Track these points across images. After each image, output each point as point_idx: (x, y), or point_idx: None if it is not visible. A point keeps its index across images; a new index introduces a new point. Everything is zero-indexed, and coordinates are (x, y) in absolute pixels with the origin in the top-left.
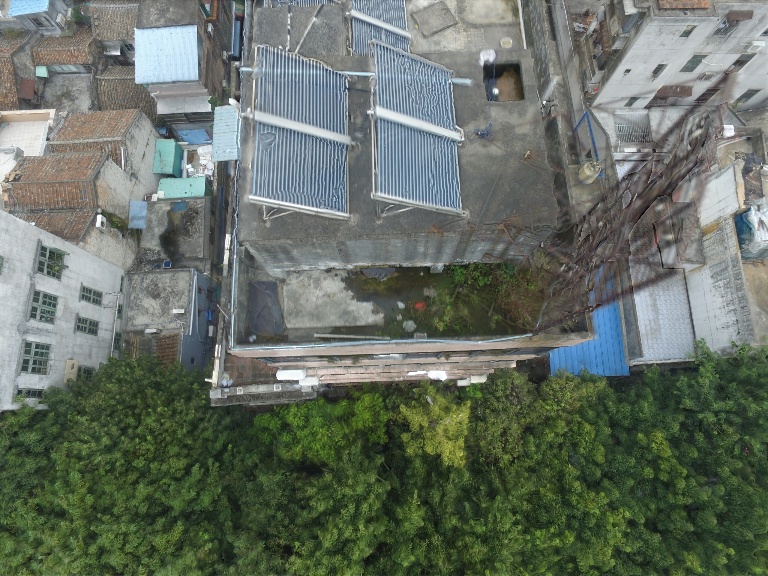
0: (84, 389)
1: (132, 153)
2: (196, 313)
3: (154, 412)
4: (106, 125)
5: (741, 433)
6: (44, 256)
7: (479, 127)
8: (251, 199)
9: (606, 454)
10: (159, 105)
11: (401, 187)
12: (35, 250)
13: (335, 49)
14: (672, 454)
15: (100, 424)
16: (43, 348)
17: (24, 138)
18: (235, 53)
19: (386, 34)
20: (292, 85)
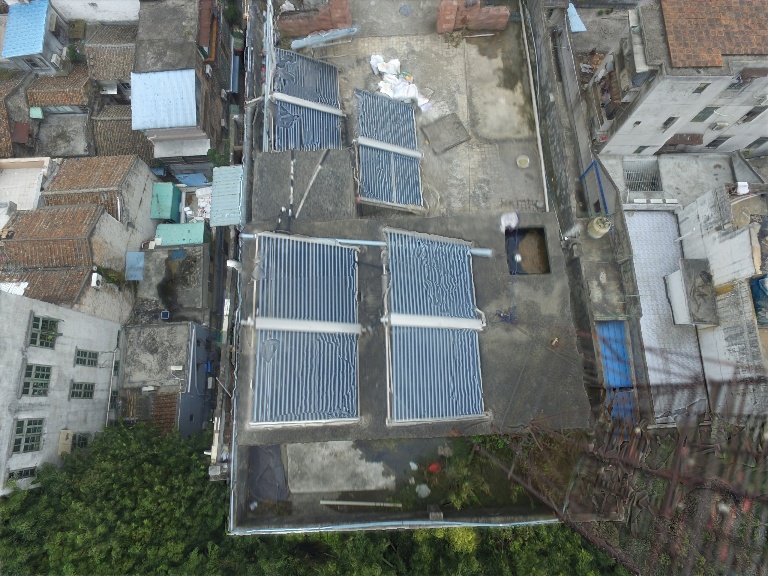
0: (79, 464)
1: (129, 202)
2: (195, 368)
3: (151, 491)
4: (102, 173)
5: (760, 516)
6: (37, 327)
7: (501, 307)
8: (252, 425)
9: (620, 535)
10: (156, 148)
11: (419, 402)
12: (27, 322)
13: (342, 204)
14: (689, 536)
15: (95, 508)
16: (36, 423)
17: (18, 186)
18: (234, 89)
19: (395, 156)
20: (297, 281)
